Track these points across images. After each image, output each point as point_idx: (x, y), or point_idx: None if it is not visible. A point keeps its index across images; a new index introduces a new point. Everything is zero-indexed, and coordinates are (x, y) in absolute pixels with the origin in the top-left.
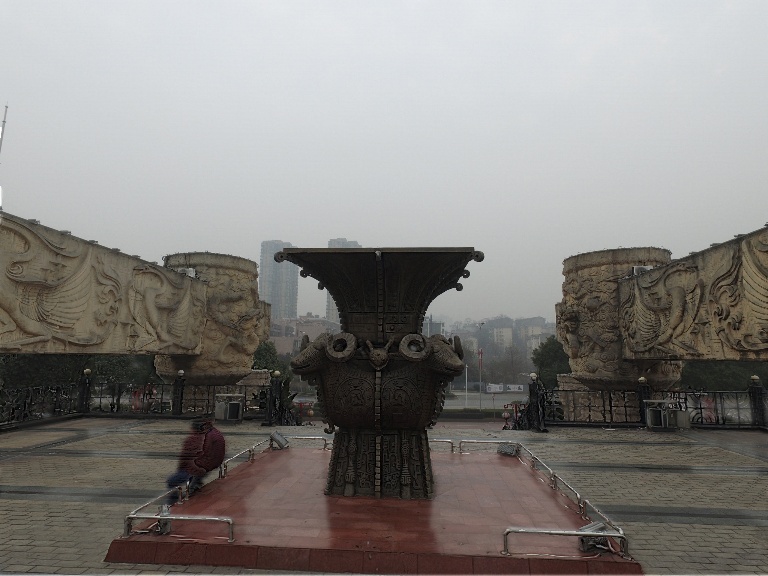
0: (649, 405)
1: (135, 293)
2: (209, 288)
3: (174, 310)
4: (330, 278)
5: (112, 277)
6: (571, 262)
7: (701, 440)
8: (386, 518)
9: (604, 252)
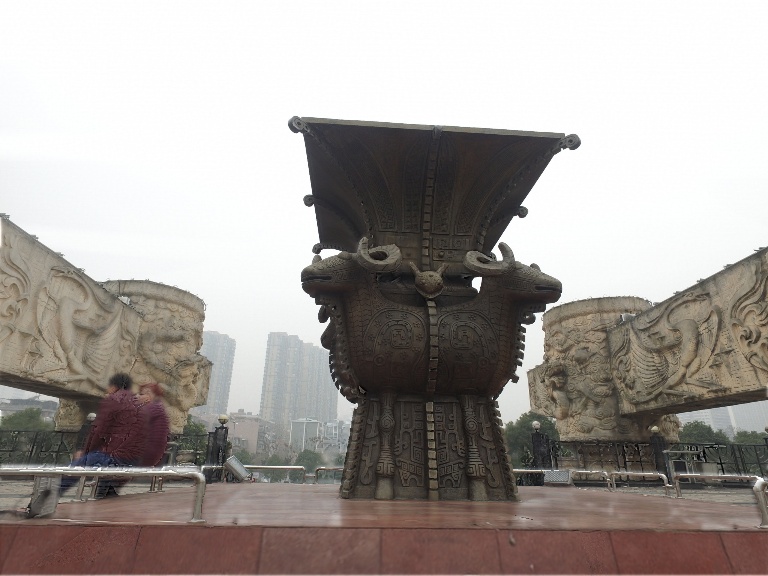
0: (671, 456)
1: (48, 299)
2: (144, 322)
3: (96, 336)
4: (358, 177)
5: (20, 268)
6: (553, 313)
7: (744, 492)
8: (479, 509)
9: (589, 300)
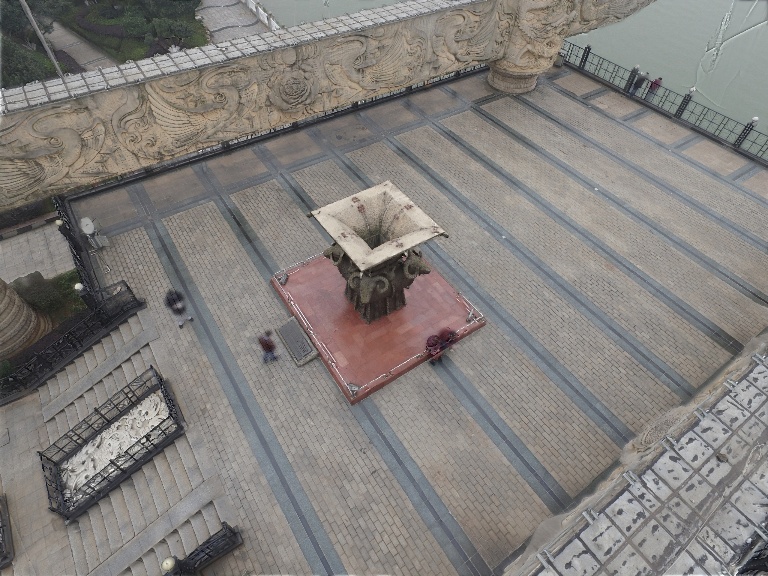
0: None
1: None
2: None
3: None
4: None
5: None
6: None
7: (135, 225)
8: None
9: None
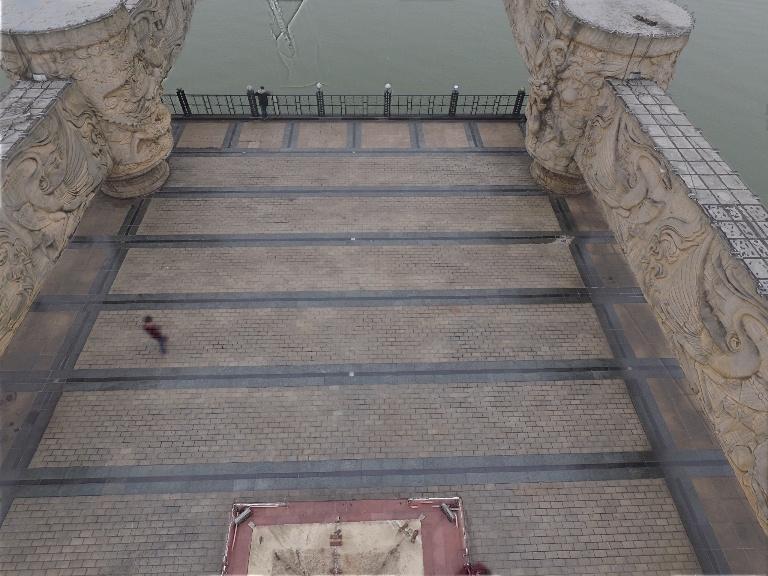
0: None
1: None
2: None
3: None
4: None
5: None
6: None
7: None
8: None
9: None
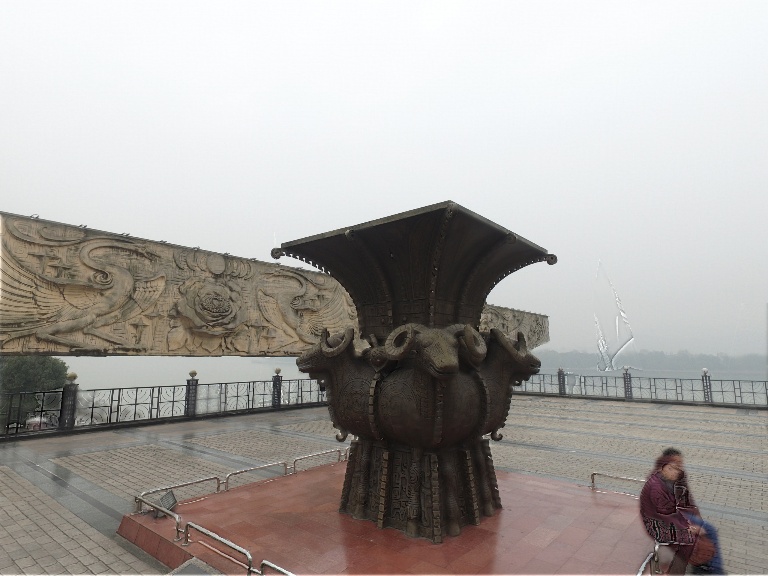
0: None
1: None
2: None
3: None
4: None
5: None
6: None
7: None
8: None
9: None
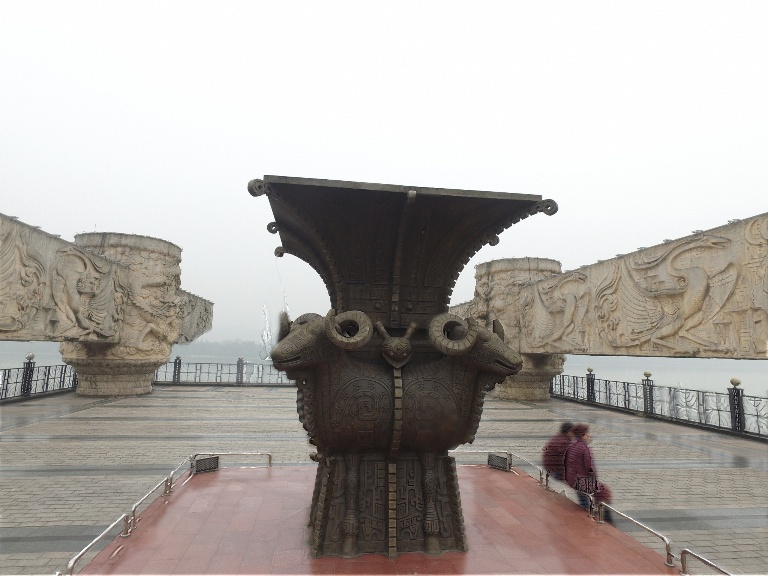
0: None
1: None
2: None
3: None
4: None
5: None
6: None
7: None
8: None
9: None
